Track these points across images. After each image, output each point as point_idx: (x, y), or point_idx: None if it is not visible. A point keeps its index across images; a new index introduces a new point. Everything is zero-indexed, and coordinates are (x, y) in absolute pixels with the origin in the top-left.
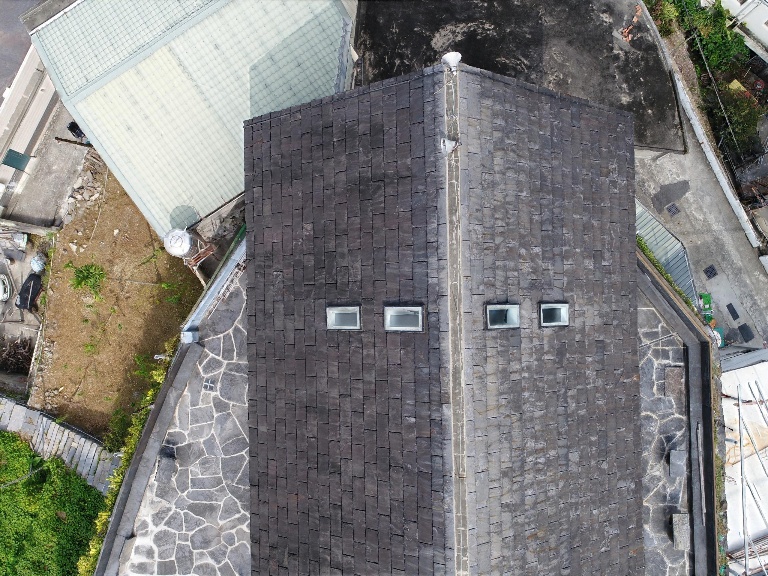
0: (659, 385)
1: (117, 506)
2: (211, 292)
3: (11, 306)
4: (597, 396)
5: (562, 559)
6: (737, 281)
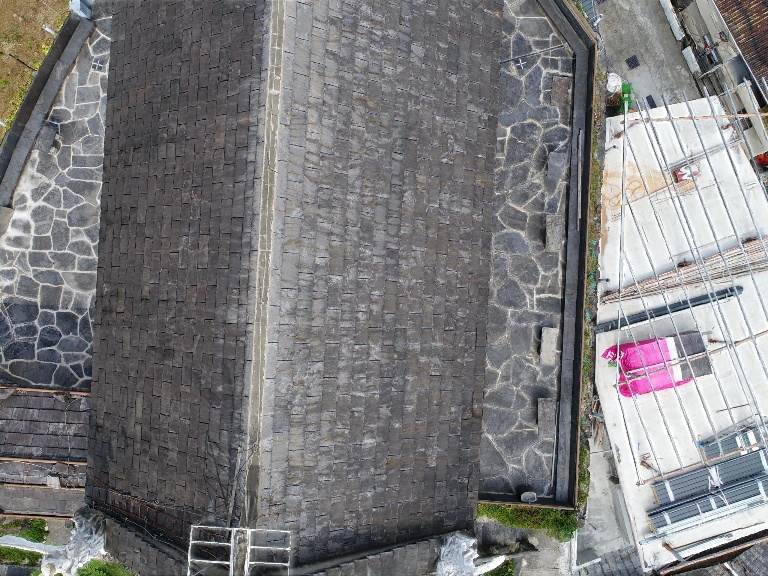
0: (546, 94)
1: None
2: None
3: None
4: (450, 8)
5: (395, 143)
6: (658, 74)
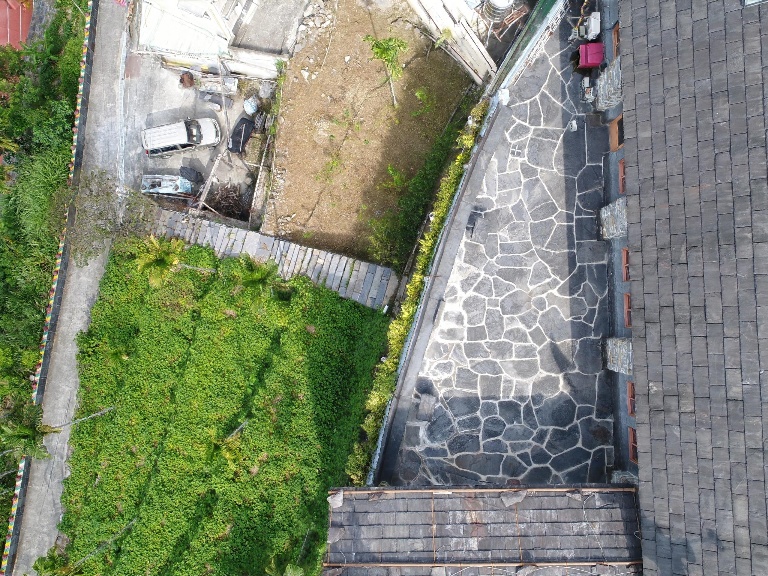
0: None
1: (436, 264)
2: (527, 51)
3: (219, 153)
4: None
5: None
6: None
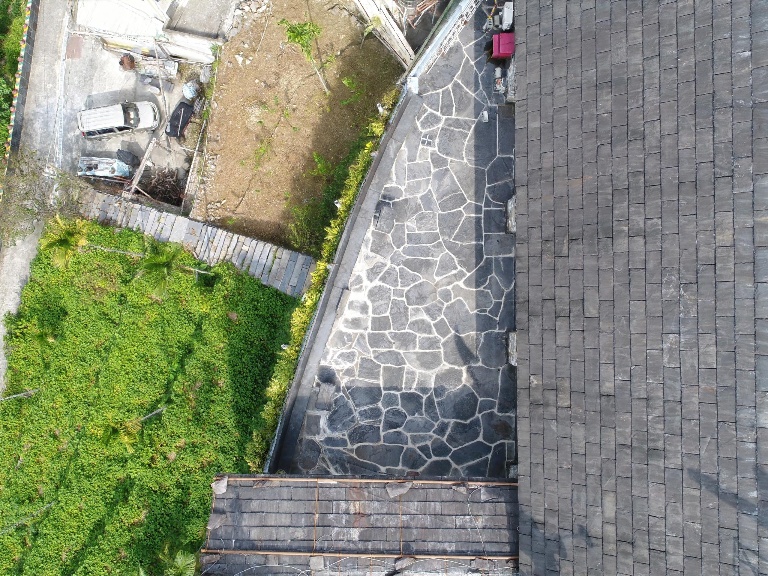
0: None
1: (339, 252)
2: (438, 39)
3: (158, 137)
4: None
5: None
6: None
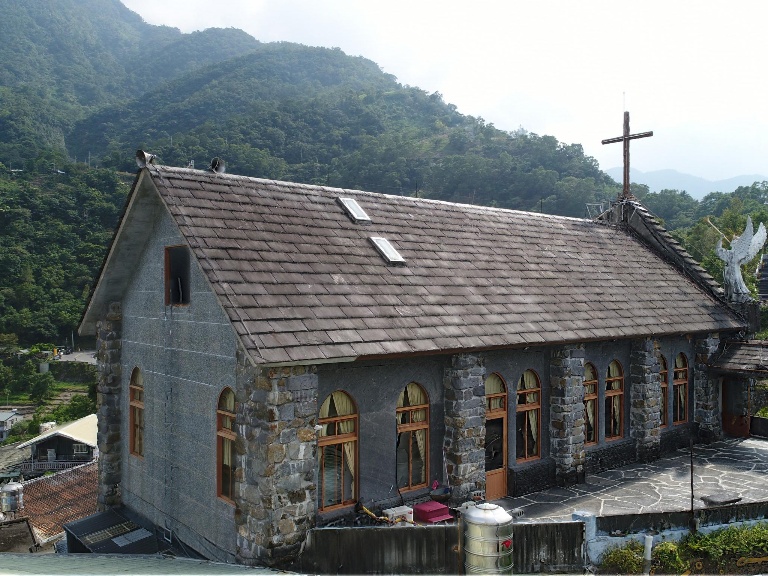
0: None
1: None
2: None
3: None
4: None
5: None
6: None
